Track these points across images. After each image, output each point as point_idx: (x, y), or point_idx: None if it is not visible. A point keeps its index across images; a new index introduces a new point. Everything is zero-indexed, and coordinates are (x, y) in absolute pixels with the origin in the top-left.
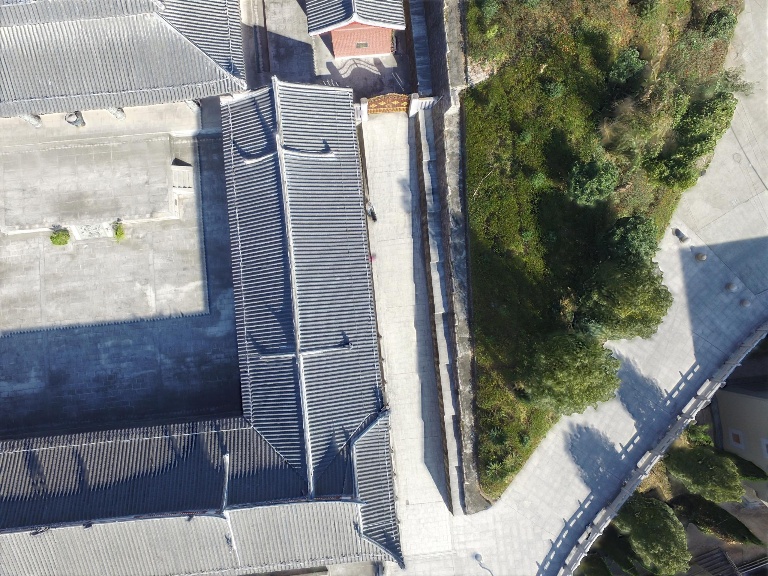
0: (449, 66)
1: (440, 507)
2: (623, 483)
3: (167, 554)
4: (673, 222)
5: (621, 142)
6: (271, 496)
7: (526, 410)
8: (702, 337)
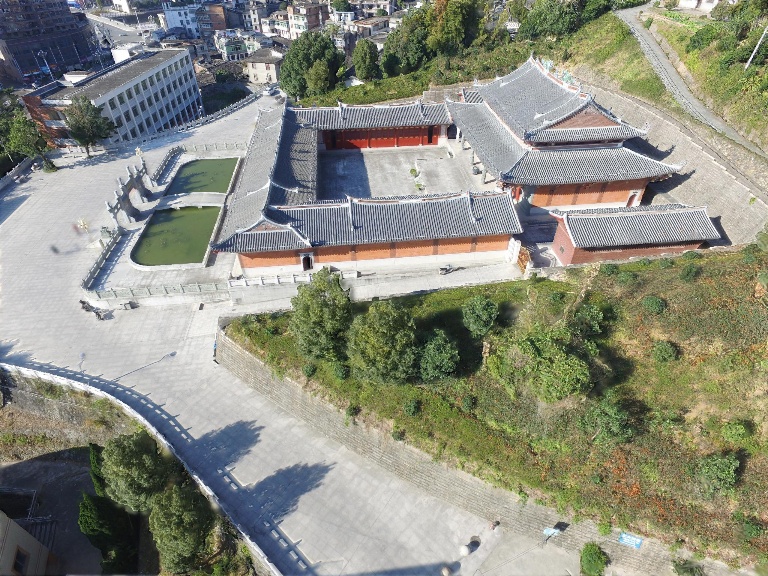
0: (558, 267)
1: None
2: (193, 470)
3: None
4: (487, 538)
5: (521, 325)
6: (272, 198)
7: None
8: (342, 574)
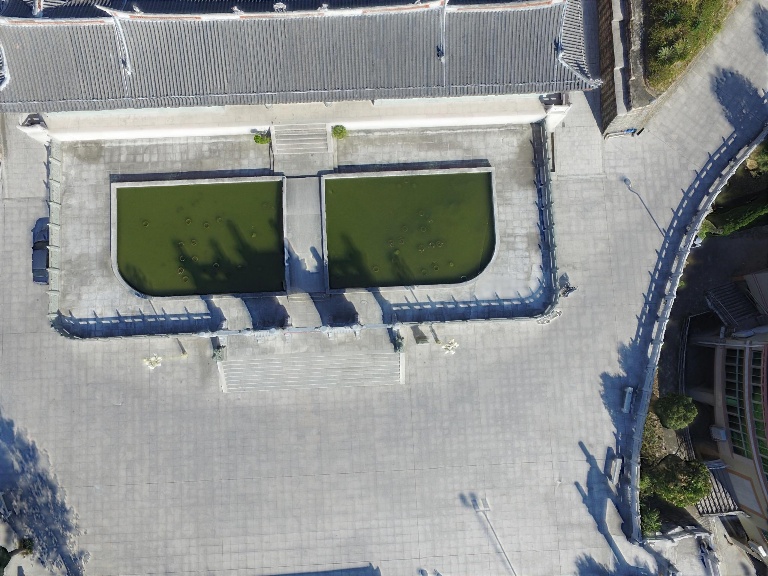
0: None
1: (594, 131)
2: (765, 124)
3: (382, 62)
4: None
5: None
6: None
7: (696, 2)
8: None
